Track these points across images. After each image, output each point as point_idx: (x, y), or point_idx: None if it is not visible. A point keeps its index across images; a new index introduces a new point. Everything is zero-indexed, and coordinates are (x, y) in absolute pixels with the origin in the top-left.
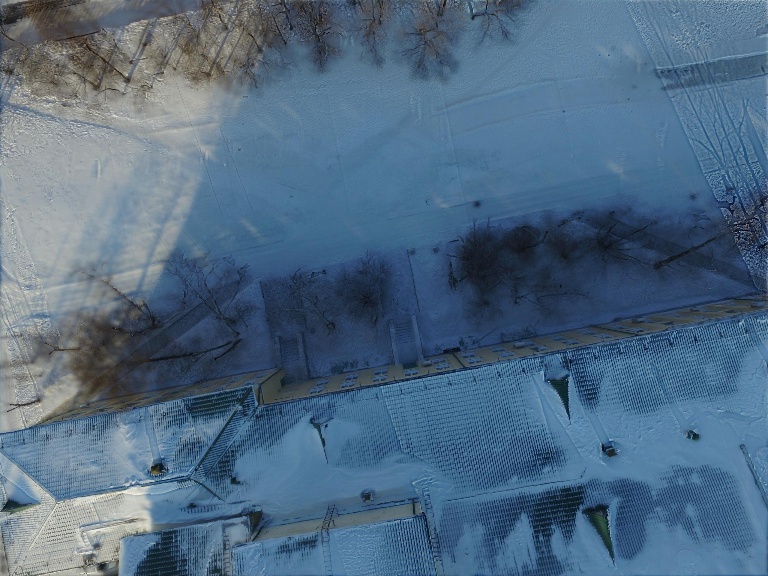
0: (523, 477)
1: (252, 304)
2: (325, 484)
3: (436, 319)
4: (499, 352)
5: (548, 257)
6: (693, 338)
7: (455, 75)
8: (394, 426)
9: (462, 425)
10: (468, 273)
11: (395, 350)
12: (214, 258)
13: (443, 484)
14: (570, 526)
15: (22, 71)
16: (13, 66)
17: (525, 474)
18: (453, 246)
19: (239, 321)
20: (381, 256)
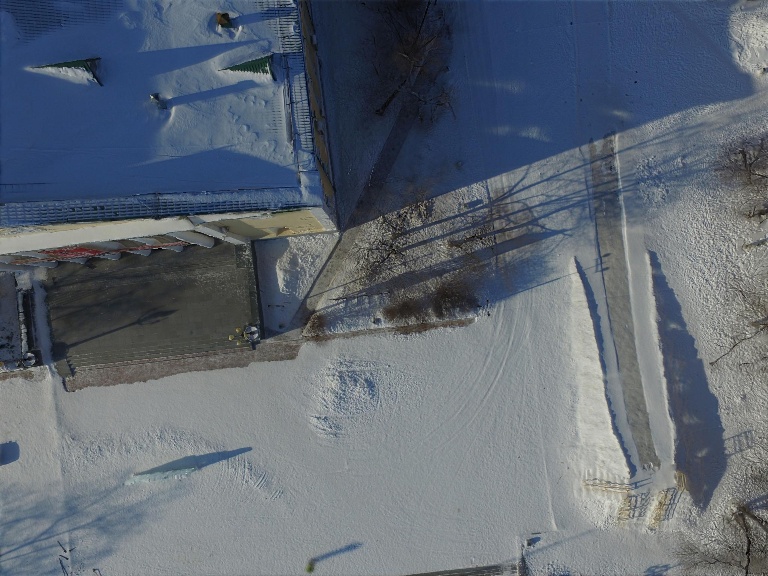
0: None
1: None
2: None
3: None
4: None
5: None
6: None
7: None
8: None
9: None
10: None
11: None
12: None
13: None
14: None
15: None
16: None
17: None
18: None
19: None
20: None
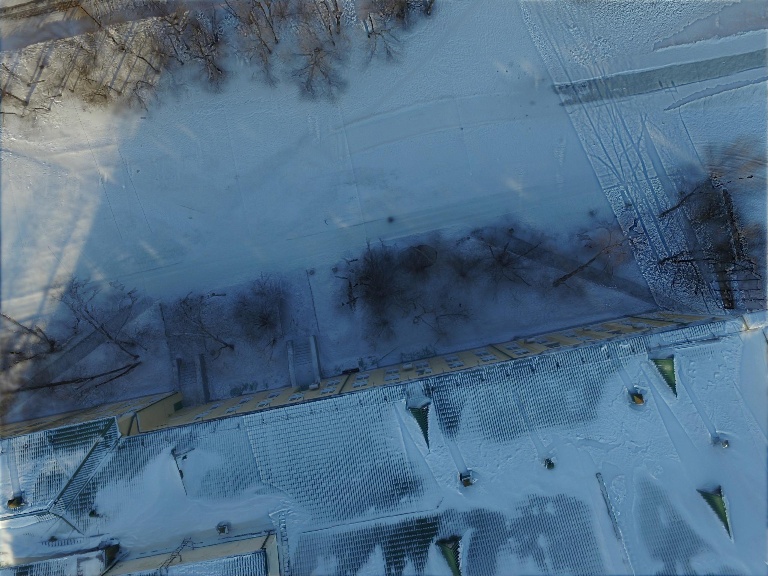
0: (380, 508)
1: (151, 327)
2: (183, 516)
3: (335, 340)
4: (388, 374)
5: (445, 276)
6: (555, 364)
7: (353, 93)
8: (255, 456)
9: (322, 455)
10: (366, 293)
11: (292, 372)
12: None
13: (300, 515)
14: (422, 558)
15: None
16: None
17: (382, 504)
18: (353, 266)
19: None
20: (281, 277)
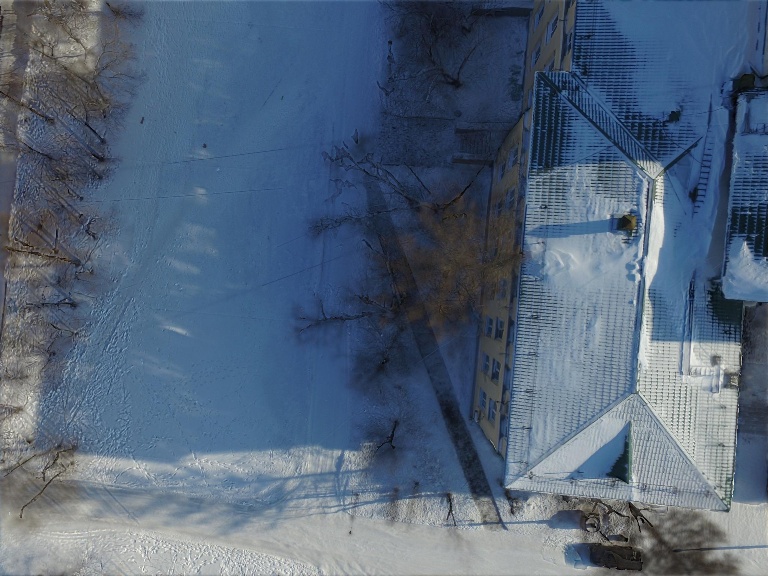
0: None
1: (402, 180)
2: None
3: None
4: None
5: None
6: None
7: None
8: None
9: None
10: None
11: (513, 4)
12: (330, 216)
13: None
14: None
15: (24, 394)
16: (14, 404)
17: None
18: None
19: None
20: None
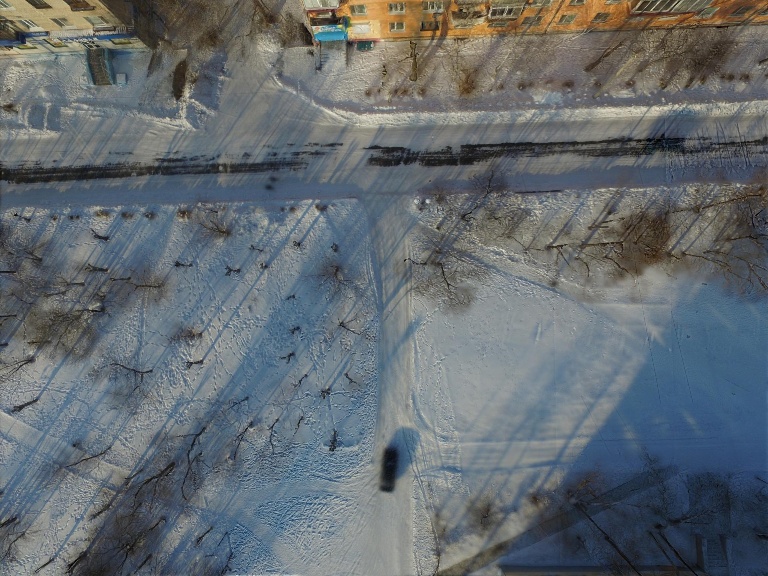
0: None
1: (678, 498)
2: None
3: None
4: None
5: None
6: None
7: None
8: None
9: None
10: None
11: None
12: (642, 442)
13: None
14: None
15: (474, 217)
16: (466, 211)
17: None
18: None
19: (662, 513)
20: None
